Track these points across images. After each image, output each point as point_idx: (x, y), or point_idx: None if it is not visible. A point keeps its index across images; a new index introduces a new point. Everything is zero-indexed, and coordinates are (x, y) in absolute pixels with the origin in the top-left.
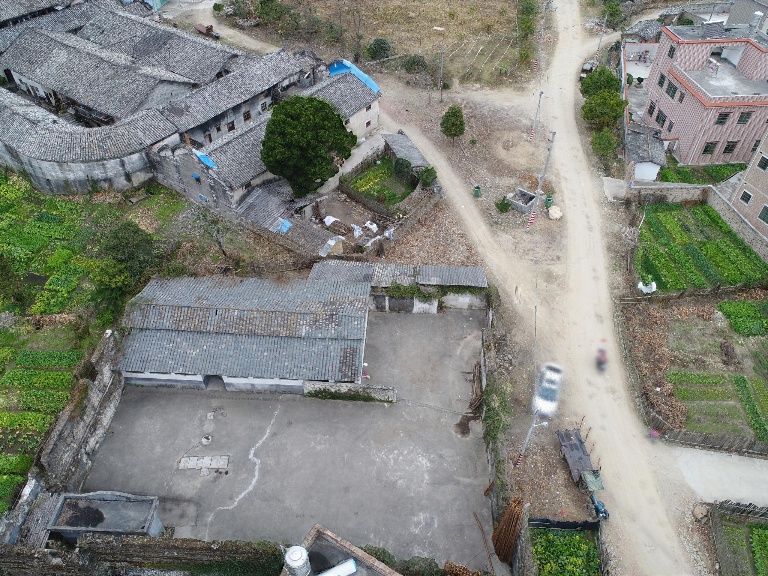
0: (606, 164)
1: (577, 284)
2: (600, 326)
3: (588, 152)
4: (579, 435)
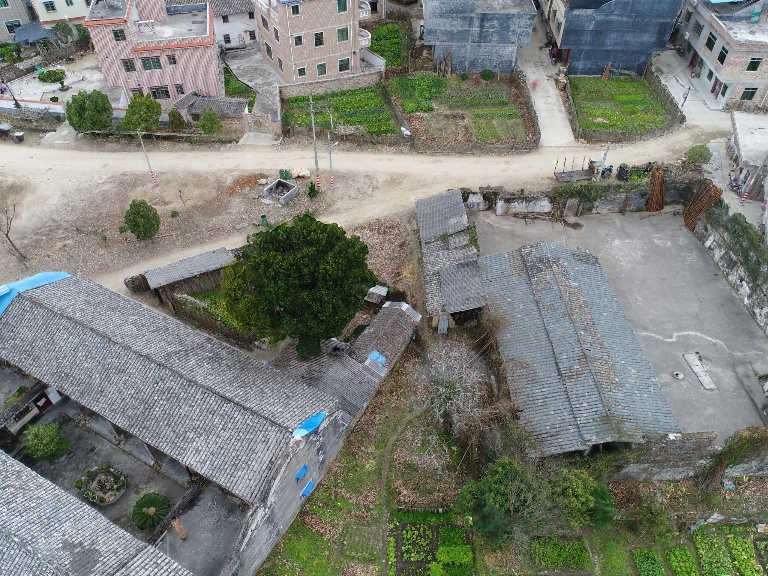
0: (211, 142)
1: (400, 169)
2: (445, 162)
3: (188, 150)
4: (559, 173)
